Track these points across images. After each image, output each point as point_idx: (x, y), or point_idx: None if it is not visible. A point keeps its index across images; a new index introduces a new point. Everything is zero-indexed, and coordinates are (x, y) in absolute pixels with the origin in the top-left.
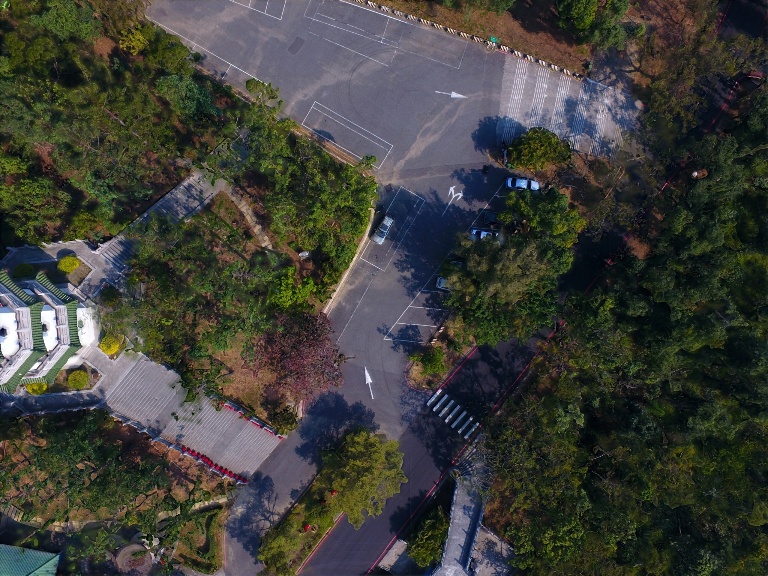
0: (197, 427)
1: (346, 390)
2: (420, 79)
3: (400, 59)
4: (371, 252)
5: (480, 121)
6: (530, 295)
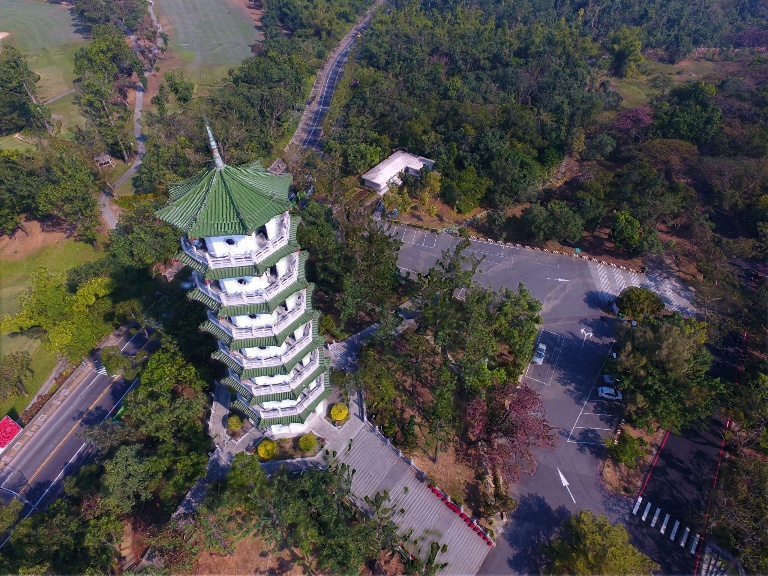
0: (407, 515)
1: (545, 492)
2: (534, 273)
3: (517, 264)
4: (533, 372)
5: (586, 293)
6: (693, 371)
